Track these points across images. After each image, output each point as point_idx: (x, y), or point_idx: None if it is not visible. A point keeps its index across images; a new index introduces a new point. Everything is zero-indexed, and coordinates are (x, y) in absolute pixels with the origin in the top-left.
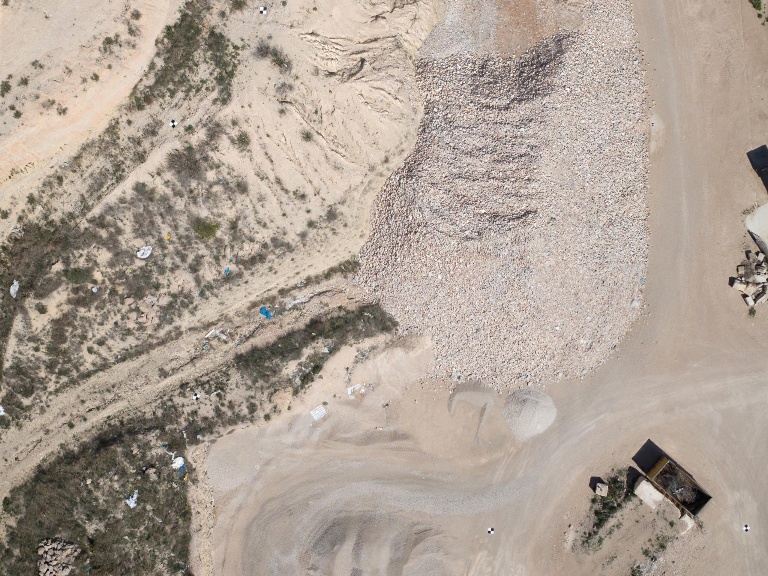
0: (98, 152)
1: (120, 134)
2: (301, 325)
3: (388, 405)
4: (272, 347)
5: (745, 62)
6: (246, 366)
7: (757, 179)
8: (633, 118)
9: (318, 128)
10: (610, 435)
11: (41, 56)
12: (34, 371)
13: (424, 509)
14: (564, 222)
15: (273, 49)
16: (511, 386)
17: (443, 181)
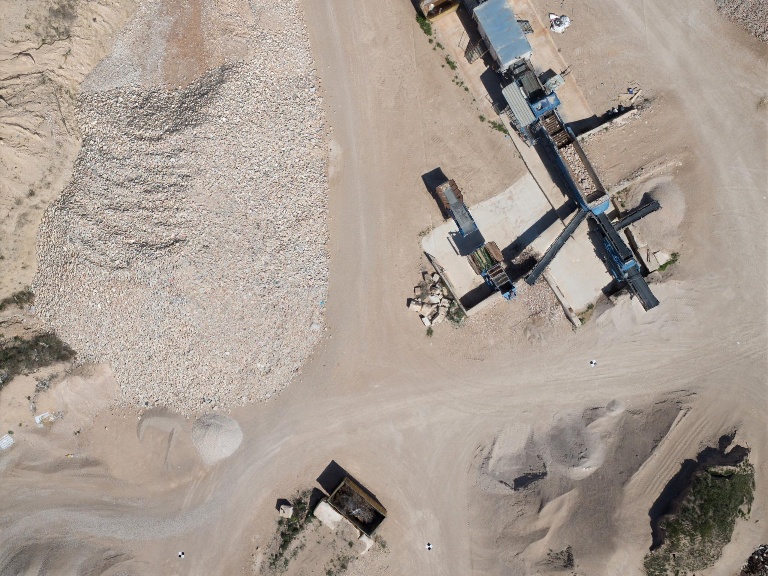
0: None
1: None
2: None
3: (79, 432)
4: None
5: (418, 87)
6: None
7: (432, 201)
8: (308, 144)
9: None
10: (295, 457)
11: None
12: None
13: (115, 535)
14: (220, 249)
15: None
16: (198, 411)
17: (96, 212)
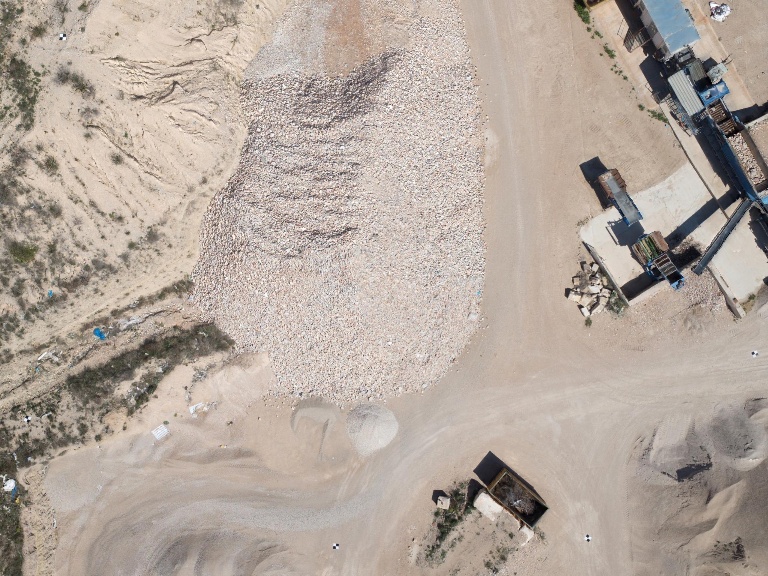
0: None
1: None
2: (135, 345)
3: (232, 423)
4: (105, 368)
5: (576, 75)
6: (77, 387)
7: (590, 191)
8: (466, 133)
9: (130, 151)
10: (451, 448)
11: None
12: None
13: (269, 526)
14: (388, 238)
15: (74, 75)
16: (352, 401)
17: (265, 200)
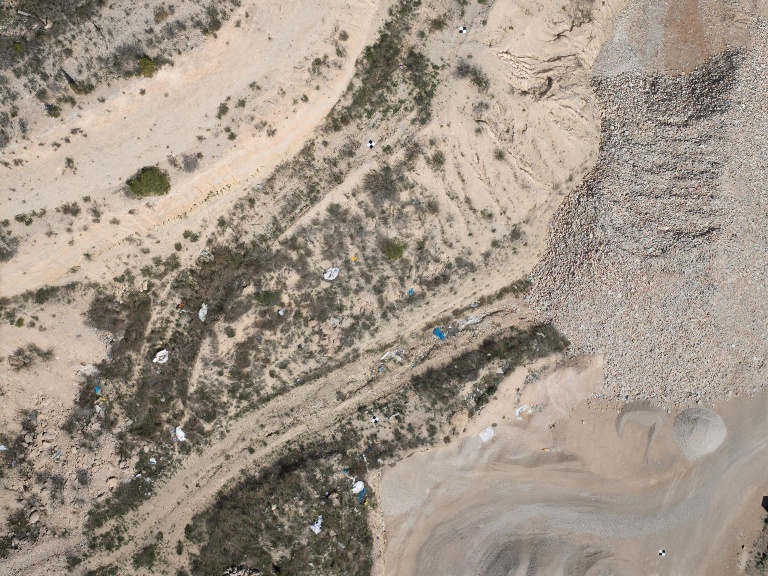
0: (292, 174)
1: (315, 155)
2: (475, 346)
3: (554, 426)
4: (448, 368)
5: None
6: (425, 388)
7: None
8: None
9: (508, 147)
10: None
11: (259, 78)
12: (217, 396)
13: (594, 531)
14: (744, 238)
15: (473, 68)
16: (680, 405)
17: (624, 199)
